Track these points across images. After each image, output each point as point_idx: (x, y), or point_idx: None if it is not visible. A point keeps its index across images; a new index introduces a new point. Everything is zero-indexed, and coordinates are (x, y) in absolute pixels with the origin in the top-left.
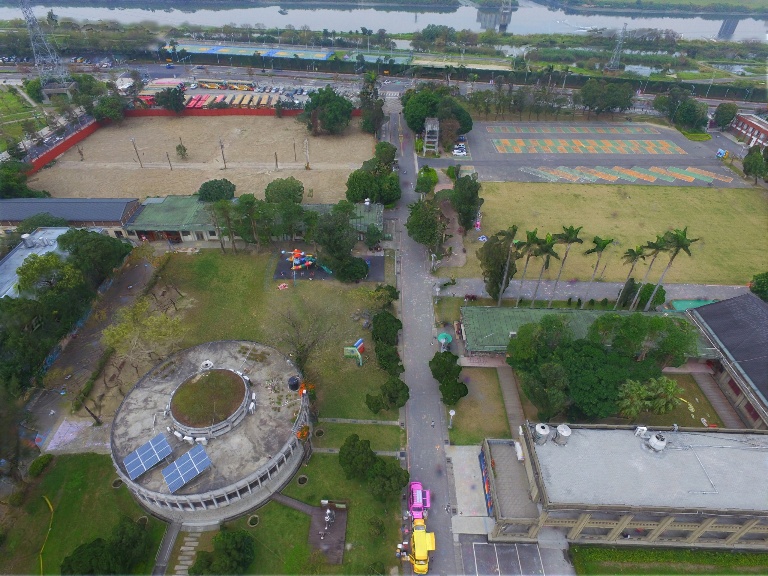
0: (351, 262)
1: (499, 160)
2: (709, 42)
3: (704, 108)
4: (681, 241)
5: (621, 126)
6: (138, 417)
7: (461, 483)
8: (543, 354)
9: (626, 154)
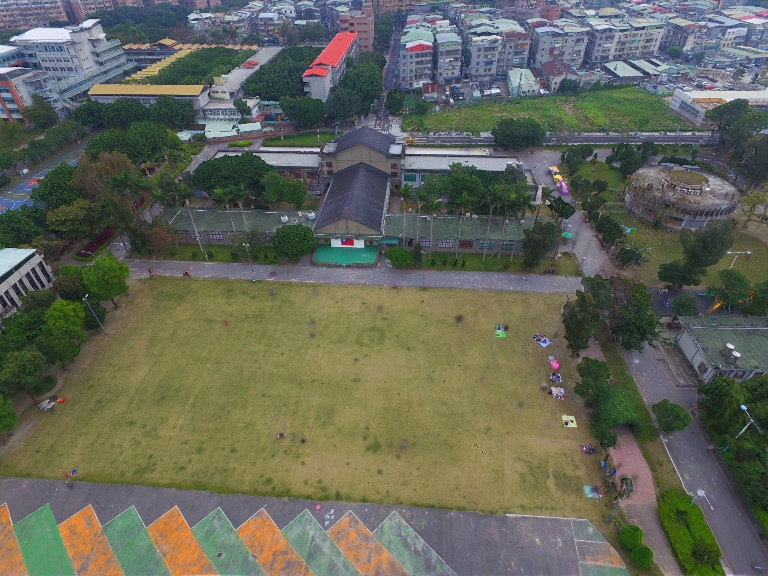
0: (680, 267)
1: None
2: None
3: None
4: None
5: None
6: (717, 182)
7: None
8: None
9: None
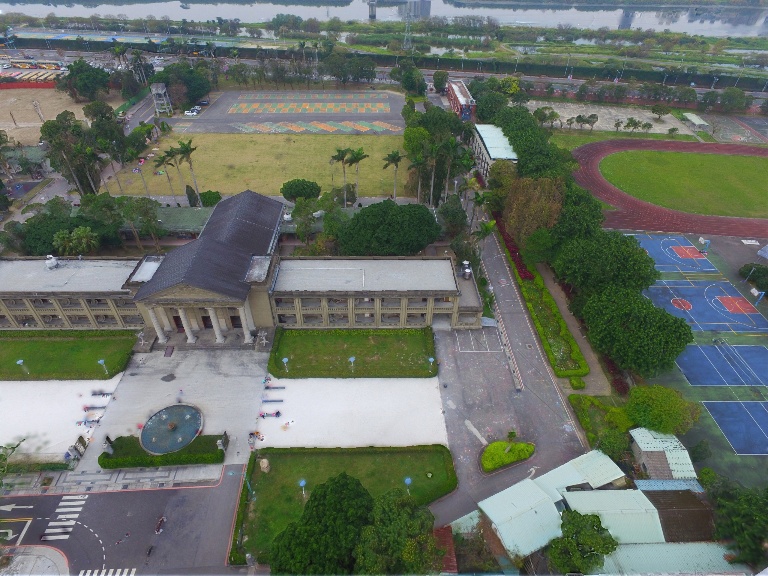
0: None
1: (220, 118)
2: (531, 28)
3: (418, 75)
4: None
5: (360, 93)
6: None
7: None
8: None
9: (336, 113)
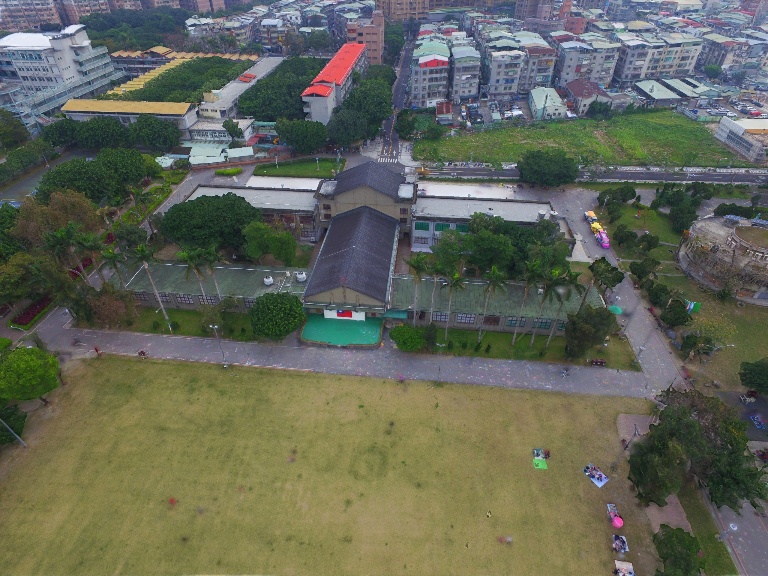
0: None
1: None
2: None
3: None
4: None
5: None
6: None
7: (580, 248)
8: None
9: None
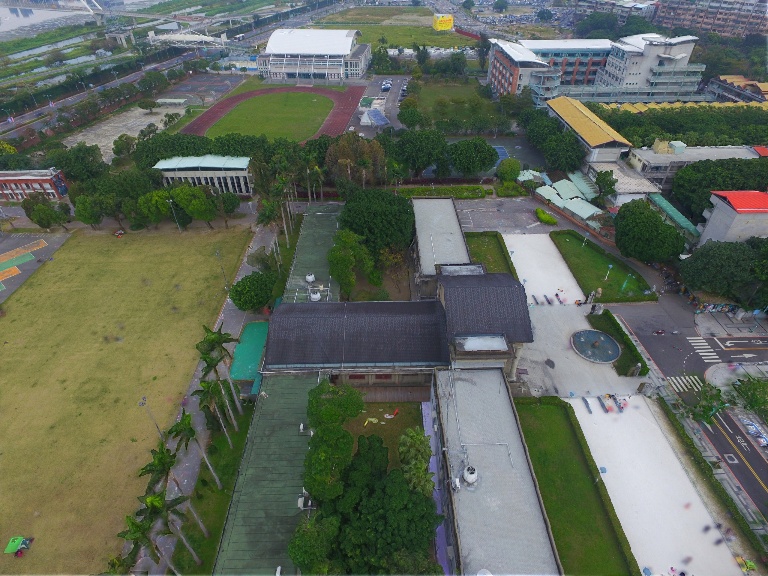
0: None
1: None
2: None
3: None
4: (220, 340)
5: None
6: None
7: None
8: (343, 572)
9: None
